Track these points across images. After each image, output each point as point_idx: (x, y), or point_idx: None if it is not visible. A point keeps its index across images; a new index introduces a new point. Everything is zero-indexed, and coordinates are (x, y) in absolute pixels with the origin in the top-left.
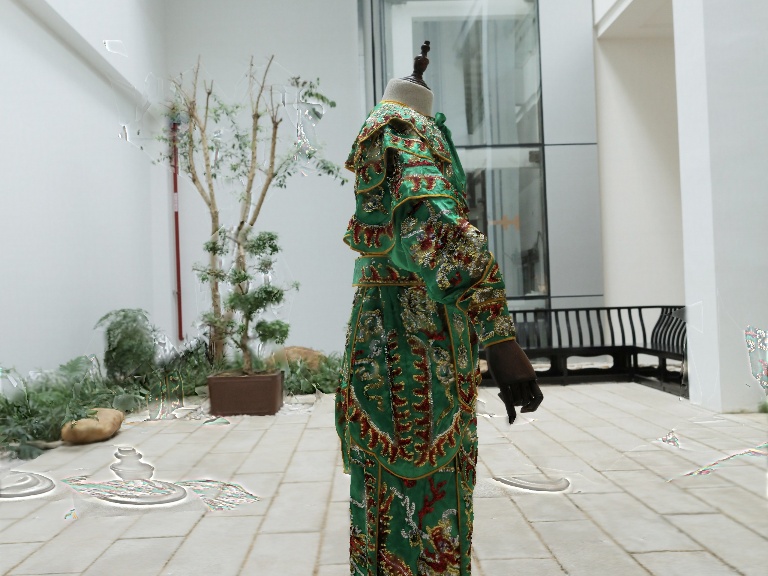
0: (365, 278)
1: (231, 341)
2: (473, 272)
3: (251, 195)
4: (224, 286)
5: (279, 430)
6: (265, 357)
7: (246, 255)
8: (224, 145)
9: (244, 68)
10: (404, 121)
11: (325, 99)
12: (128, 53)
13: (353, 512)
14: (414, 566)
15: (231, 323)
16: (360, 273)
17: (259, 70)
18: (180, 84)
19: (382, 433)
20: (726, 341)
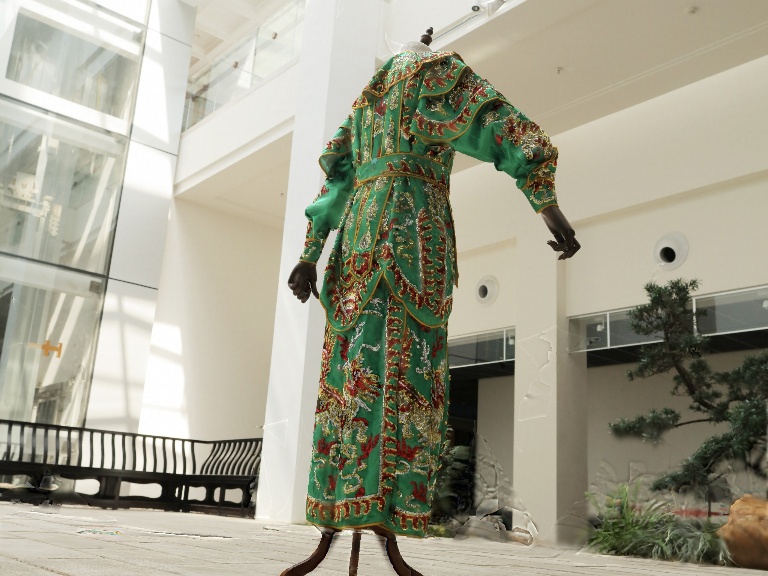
0: (394, 169)
1: None
2: (546, 154)
3: None
4: None
5: None
6: None
7: None
8: None
9: None
10: None
11: None
12: None
13: (366, 355)
14: (429, 395)
15: None
16: (381, 168)
17: None
18: None
19: (411, 285)
20: (303, 457)
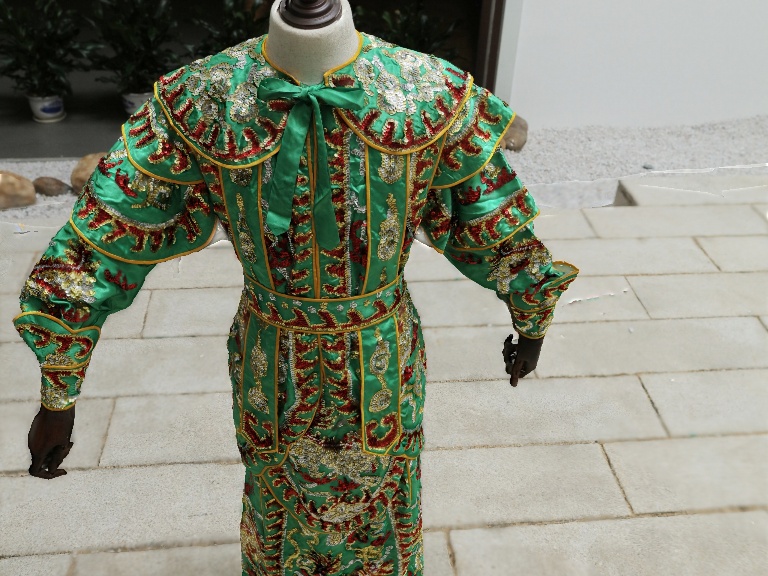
0: None
1: None
2: None
3: None
4: None
5: None
6: None
7: None
8: None
9: None
10: None
11: None
12: None
13: None
14: None
15: None
16: None
17: None
18: None
19: None
20: None
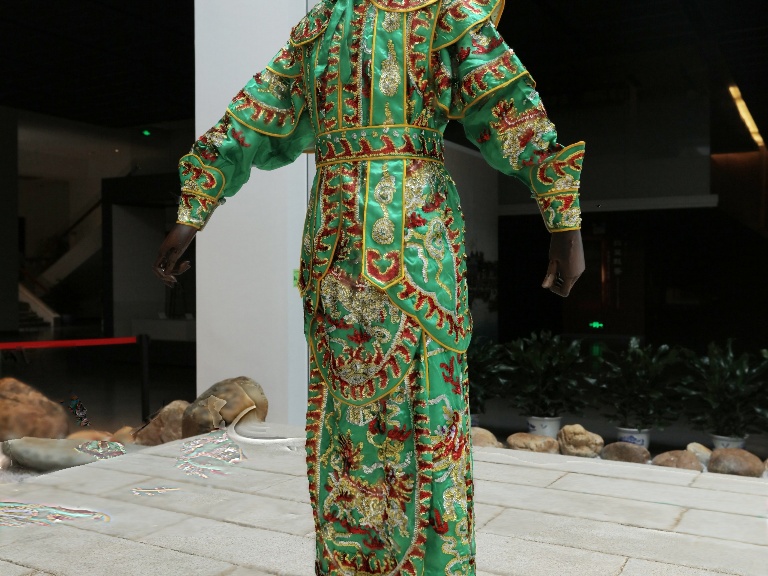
0: None
1: None
2: None
3: None
4: None
5: None
6: None
7: None
8: None
9: None
10: None
11: None
12: None
13: None
14: None
15: None
16: None
17: None
18: None
19: None
20: None
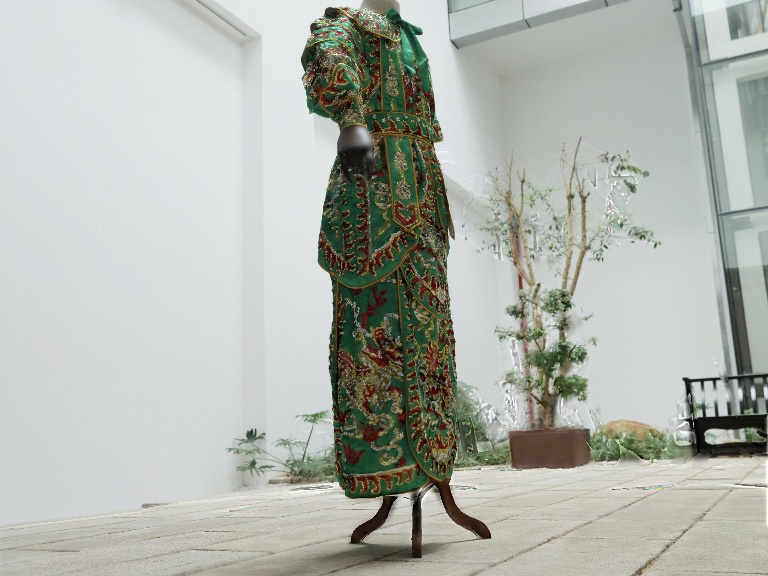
0: None
1: (531, 397)
2: (328, 79)
3: (568, 271)
4: (521, 344)
5: (561, 471)
6: (568, 414)
7: (543, 314)
8: (541, 228)
9: (556, 155)
10: (334, 8)
11: (637, 170)
12: (455, 160)
13: None
14: (356, 357)
15: (527, 378)
16: None
17: (569, 153)
18: (497, 177)
19: (338, 254)
20: None
